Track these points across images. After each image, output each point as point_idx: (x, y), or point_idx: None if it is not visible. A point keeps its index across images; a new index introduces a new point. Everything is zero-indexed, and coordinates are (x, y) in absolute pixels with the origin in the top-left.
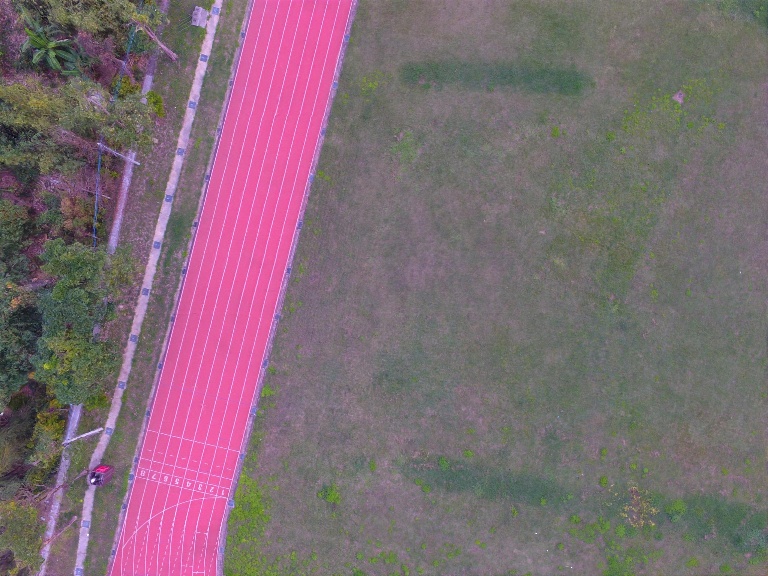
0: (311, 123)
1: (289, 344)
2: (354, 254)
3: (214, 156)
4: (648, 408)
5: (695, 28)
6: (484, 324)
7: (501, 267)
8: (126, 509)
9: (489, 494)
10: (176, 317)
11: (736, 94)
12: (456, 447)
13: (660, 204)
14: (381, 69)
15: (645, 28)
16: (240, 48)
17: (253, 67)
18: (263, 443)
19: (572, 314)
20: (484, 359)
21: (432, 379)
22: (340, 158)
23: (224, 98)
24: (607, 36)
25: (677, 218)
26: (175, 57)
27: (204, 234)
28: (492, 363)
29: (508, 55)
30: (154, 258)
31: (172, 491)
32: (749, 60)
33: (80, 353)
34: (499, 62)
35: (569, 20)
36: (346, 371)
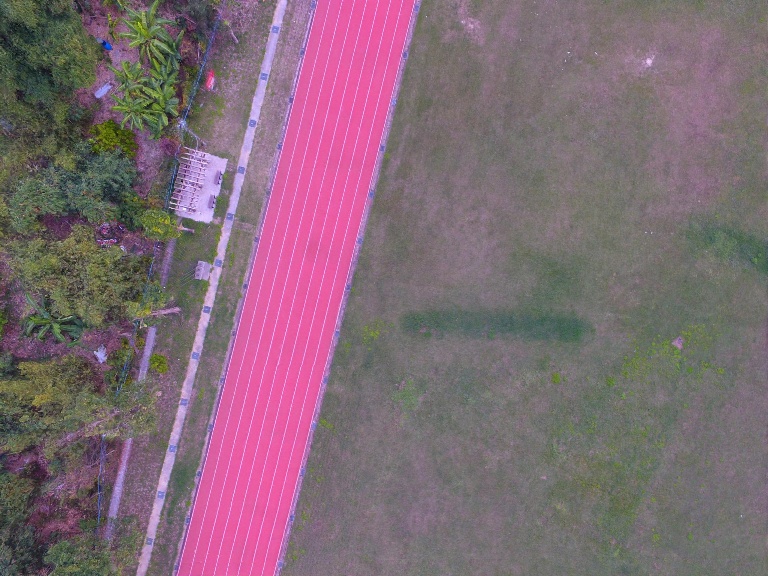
0: (313, 372)
1: None
2: (357, 502)
3: (217, 406)
4: None
5: (694, 275)
6: (486, 570)
7: (503, 513)
8: None
9: None
10: (180, 566)
11: (735, 339)
12: None
13: (661, 449)
14: (382, 318)
15: (644, 275)
16: (243, 299)
17: (256, 318)
18: None
19: (574, 559)
20: None
21: None
22: (342, 406)
23: (227, 348)
24: (606, 283)
25: (678, 462)
26: (178, 311)
27: (207, 483)
28: None
29: (508, 303)
30: (158, 508)
31: None
32: (748, 306)
33: None
34: (499, 310)
35: (569, 268)
36: None
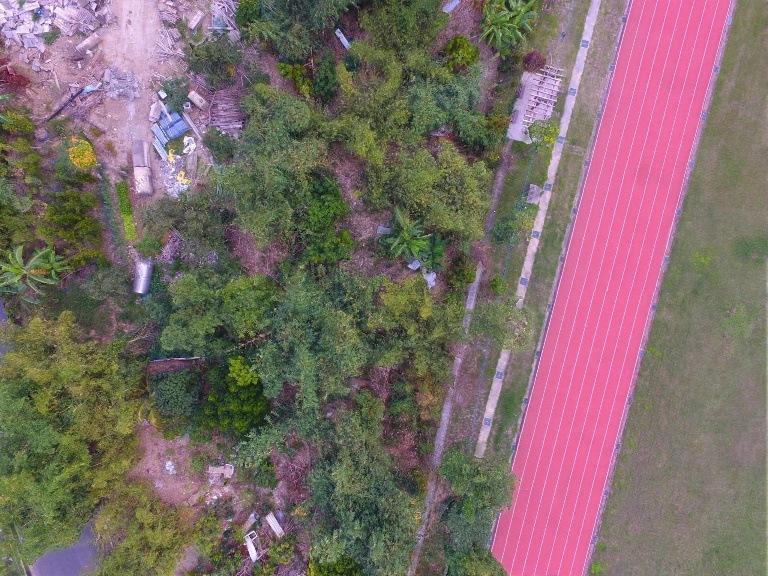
0: (642, 298)
1: (619, 520)
2: (685, 430)
3: (545, 332)
4: None
5: None
6: None
7: None
8: None
9: None
10: None
11: None
12: None
13: None
14: (714, 244)
15: None
16: (572, 224)
17: (585, 243)
18: None
19: None
20: None
21: (763, 556)
22: (671, 334)
23: (555, 274)
24: None
25: None
26: None
27: (535, 411)
28: None
29: None
30: (484, 435)
31: None
32: None
33: None
34: None
35: None
36: (676, 547)
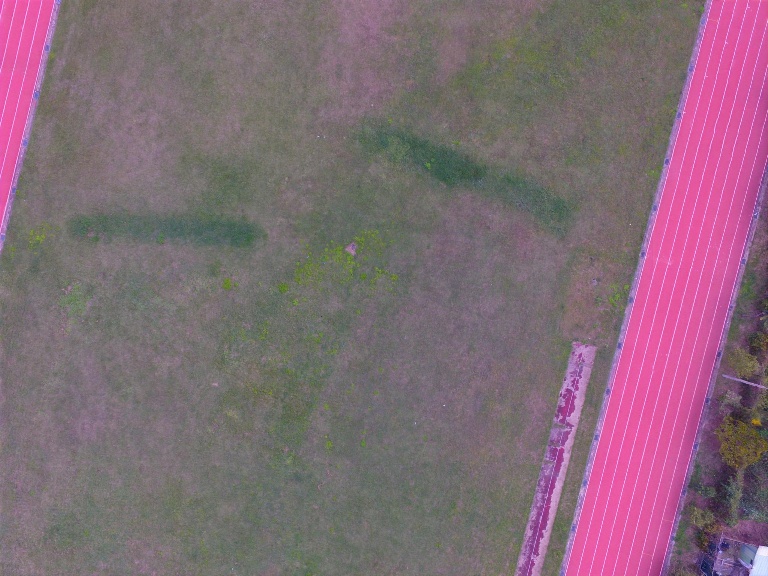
0: None
1: None
2: (23, 408)
3: None
4: (323, 559)
5: (367, 180)
6: (157, 477)
7: (173, 420)
8: None
9: None
10: None
11: (409, 245)
12: None
13: (334, 356)
14: (49, 222)
15: (317, 180)
16: None
17: None
18: None
19: (246, 466)
20: (157, 512)
21: (104, 533)
22: (8, 311)
23: None
24: (278, 188)
25: (351, 369)
26: None
27: None
28: (165, 516)
29: (178, 207)
30: None
31: None
32: (422, 212)
33: None
34: (169, 214)
35: (239, 172)
36: (16, 526)
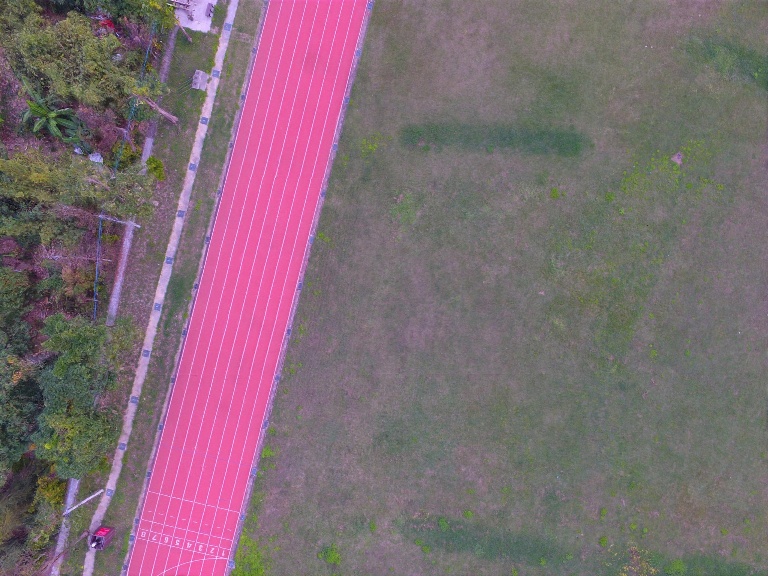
0: (311, 185)
1: (289, 405)
2: (354, 315)
3: (214, 218)
4: (647, 468)
5: (694, 90)
6: (484, 385)
7: (501, 328)
8: (127, 570)
9: (489, 554)
10: (176, 378)
11: (735, 155)
12: (456, 507)
13: (659, 265)
14: (381, 131)
15: (644, 90)
16: (240, 110)
17: (253, 129)
18: (263, 504)
19: (571, 374)
20: (484, 420)
21: (432, 440)
22: (340, 220)
23: (224, 160)
24: (606, 98)
25: (676, 279)
26: (175, 120)
27: (204, 296)
28: (492, 424)
29: (507, 117)
30: (155, 320)
31: (173, 552)
32: (747, 121)
33: (81, 430)
34: (498, 124)
35: (568, 82)
36: (346, 432)
